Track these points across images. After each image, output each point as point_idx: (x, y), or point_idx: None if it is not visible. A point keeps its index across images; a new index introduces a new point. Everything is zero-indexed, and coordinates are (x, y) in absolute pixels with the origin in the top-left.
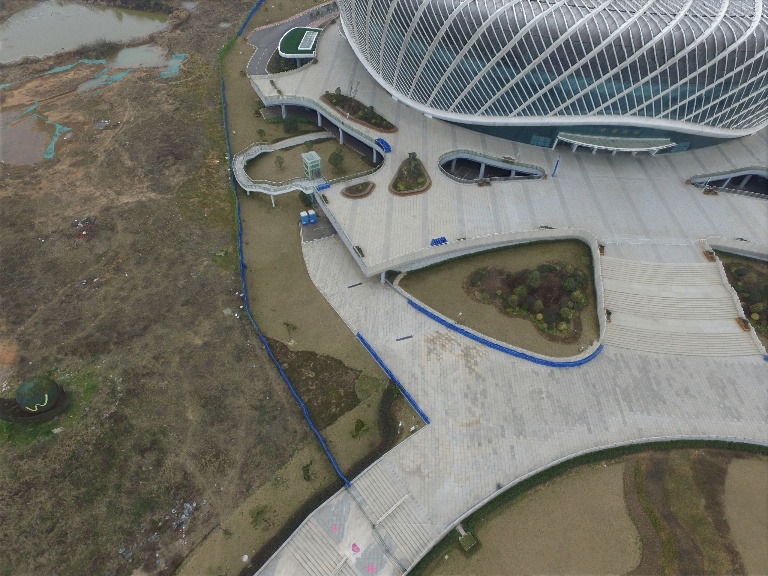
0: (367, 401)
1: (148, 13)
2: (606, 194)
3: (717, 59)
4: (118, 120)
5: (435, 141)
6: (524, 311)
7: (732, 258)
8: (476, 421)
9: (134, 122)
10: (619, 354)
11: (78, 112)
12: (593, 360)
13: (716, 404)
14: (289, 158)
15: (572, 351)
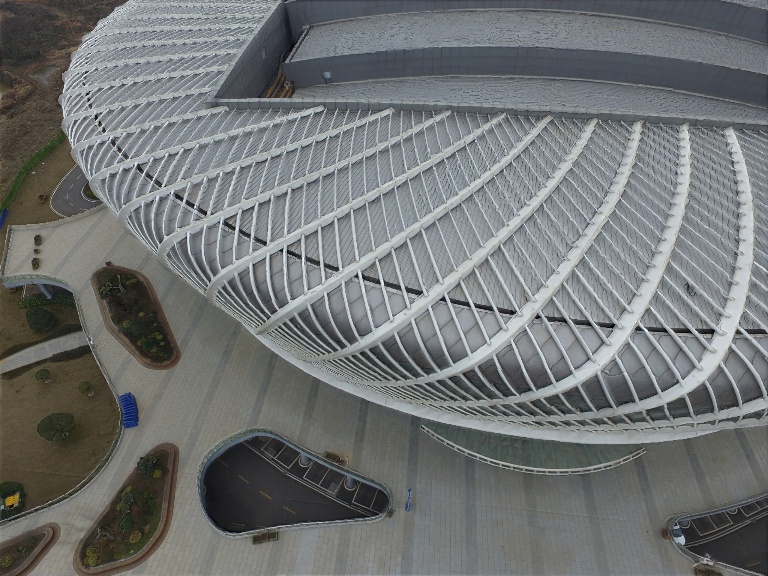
0: None
1: None
2: (497, 574)
3: (717, 418)
4: None
5: (228, 393)
6: None
7: None
8: None
9: None
10: None
11: None
12: None
13: None
14: (6, 398)
15: None
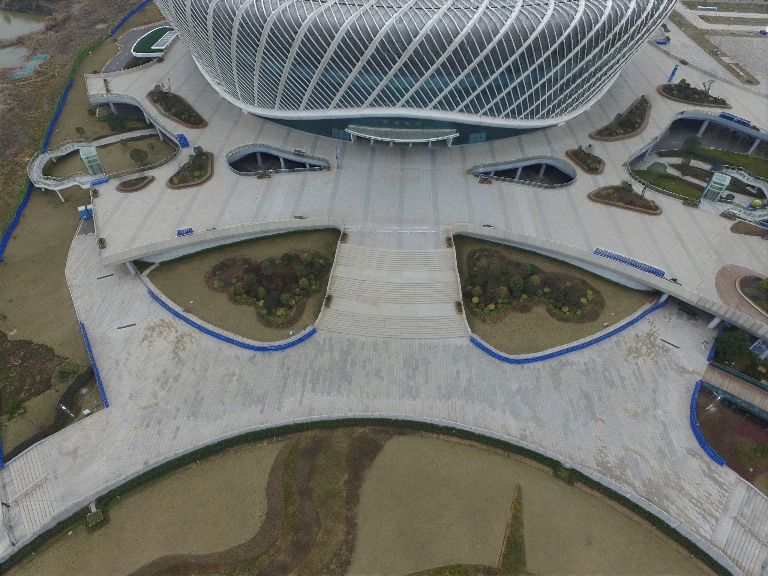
0: (57, 386)
1: (31, 15)
2: (381, 184)
3: (449, 50)
4: None
5: (238, 136)
6: (252, 298)
7: (483, 244)
8: (155, 404)
9: None
10: (329, 338)
11: None
12: (300, 344)
13: (400, 384)
14: (102, 155)
15: (282, 336)
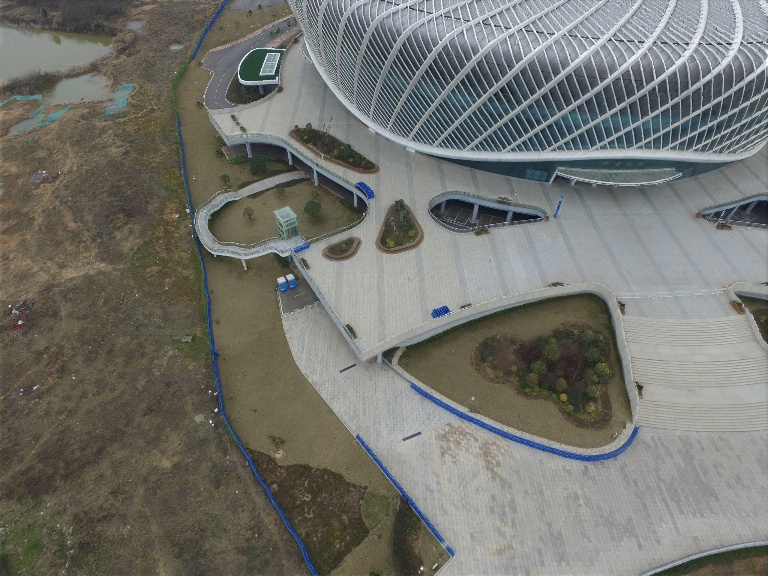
0: (377, 530)
1: (89, 36)
2: (615, 236)
3: (734, 90)
4: (58, 170)
5: (422, 181)
6: (545, 390)
7: (757, 304)
8: (508, 546)
9: (77, 172)
10: (657, 437)
11: (10, 162)
12: (629, 448)
13: None
14: (259, 207)
15: (605, 438)
